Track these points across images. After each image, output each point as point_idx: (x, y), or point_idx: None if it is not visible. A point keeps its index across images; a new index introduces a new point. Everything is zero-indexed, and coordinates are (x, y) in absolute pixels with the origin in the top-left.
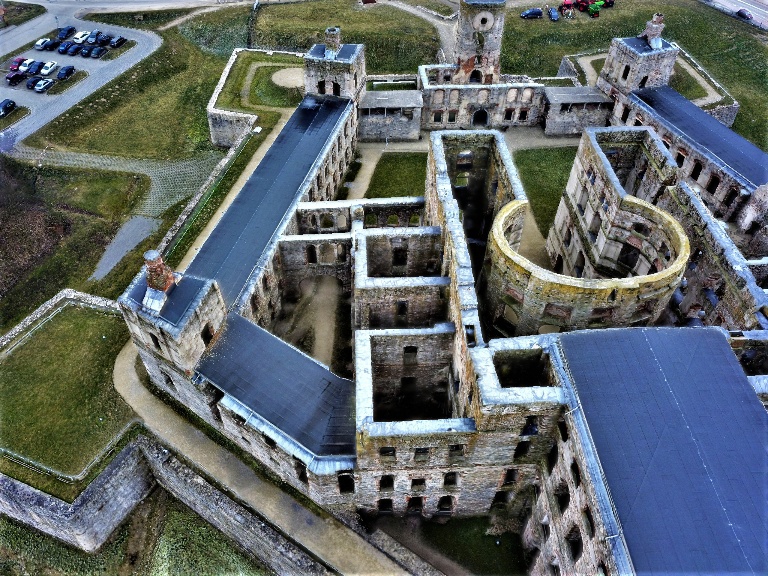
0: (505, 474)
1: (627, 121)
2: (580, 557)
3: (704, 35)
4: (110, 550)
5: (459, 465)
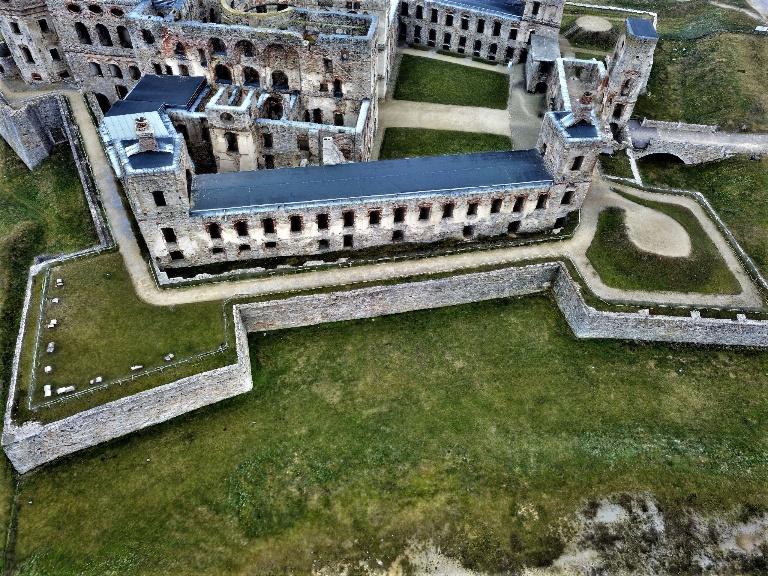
0: None
1: None
2: None
3: None
4: None
5: None
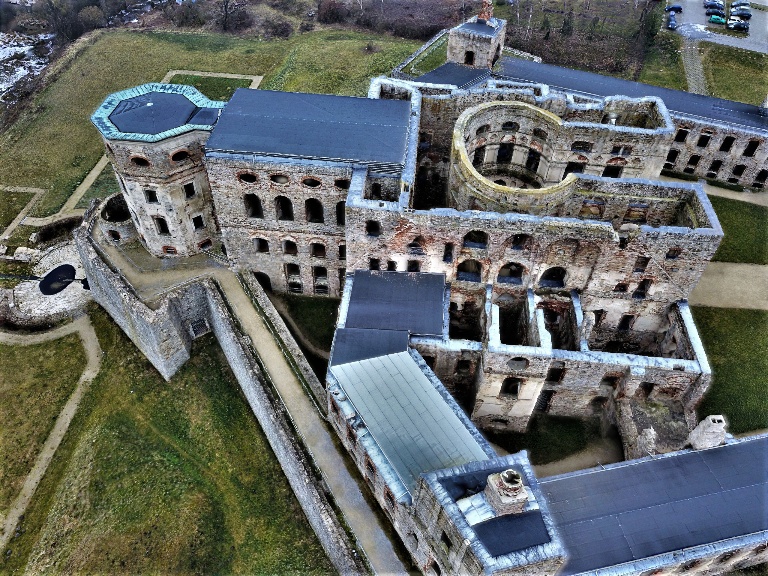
0: None
1: None
2: None
3: None
4: None
5: None
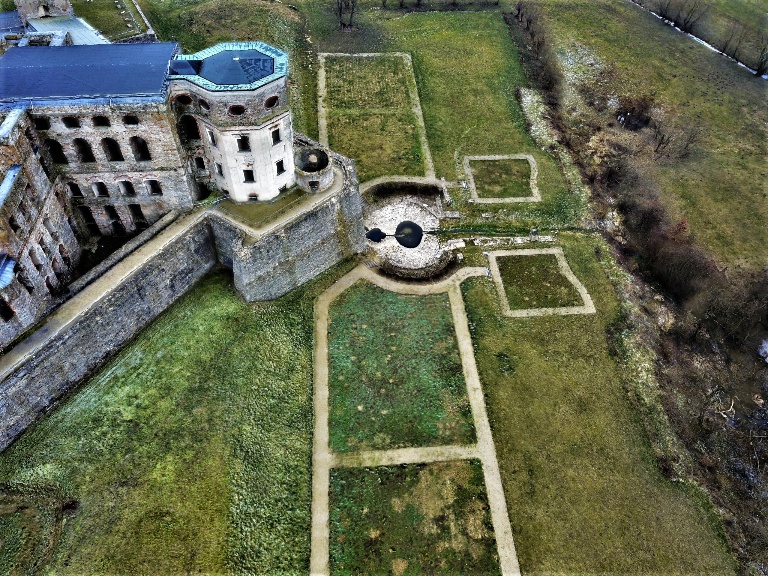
0: (57, 199)
1: None
2: (119, 147)
3: None
4: (5, 529)
5: (40, 207)
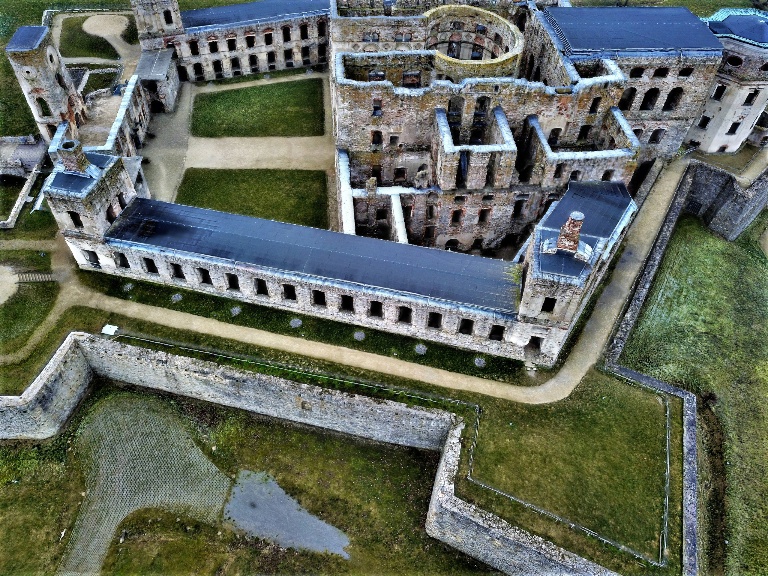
0: None
1: (201, 51)
2: (659, 97)
3: (19, 1)
4: None
5: None
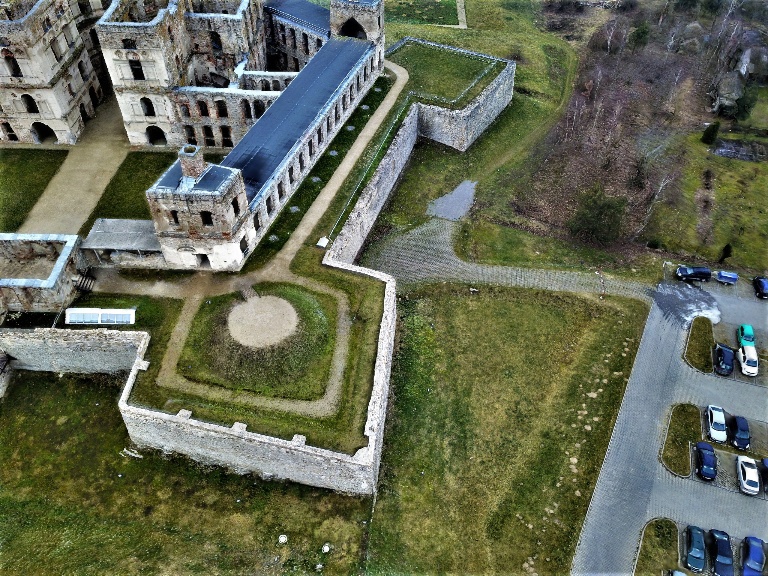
0: None
1: None
2: None
3: None
4: None
5: None
